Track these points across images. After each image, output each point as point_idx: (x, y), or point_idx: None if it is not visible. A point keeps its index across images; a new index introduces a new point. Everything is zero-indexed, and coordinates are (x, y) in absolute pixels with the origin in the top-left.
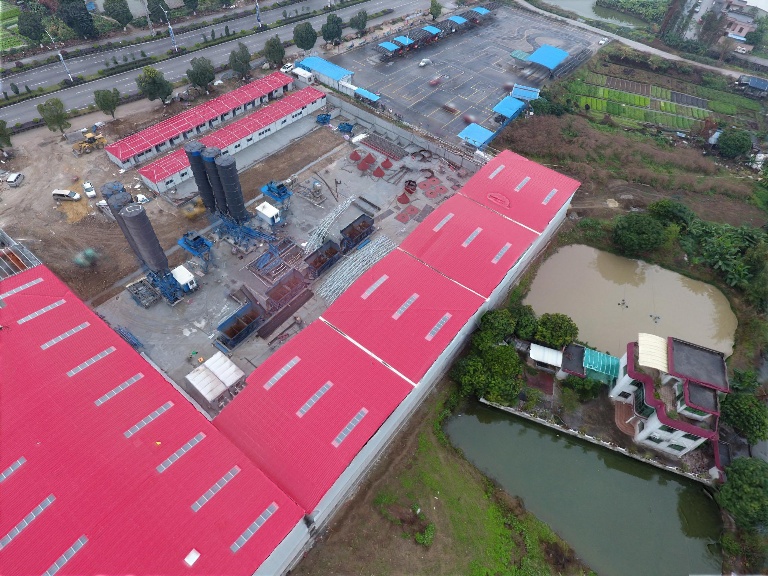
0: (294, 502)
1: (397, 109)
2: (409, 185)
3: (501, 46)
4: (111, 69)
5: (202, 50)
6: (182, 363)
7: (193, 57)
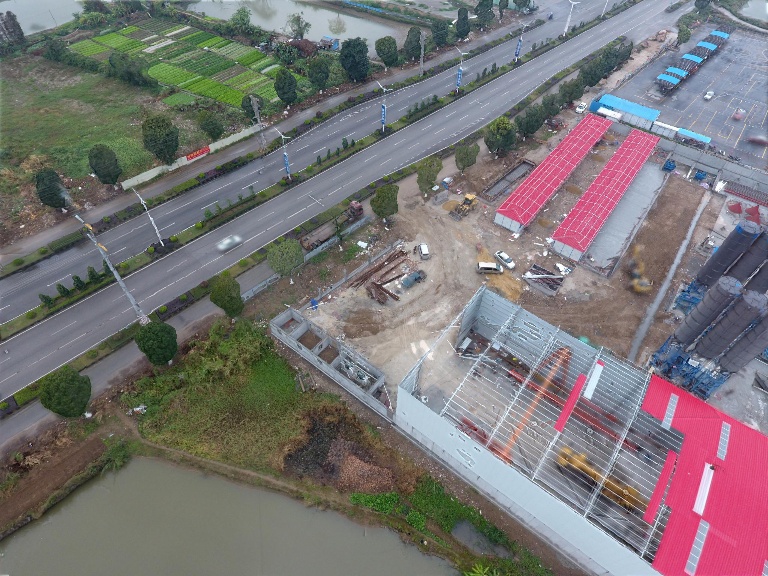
0: None
1: (726, 150)
2: None
3: (765, 73)
4: (410, 116)
5: (477, 90)
6: None
7: (475, 98)
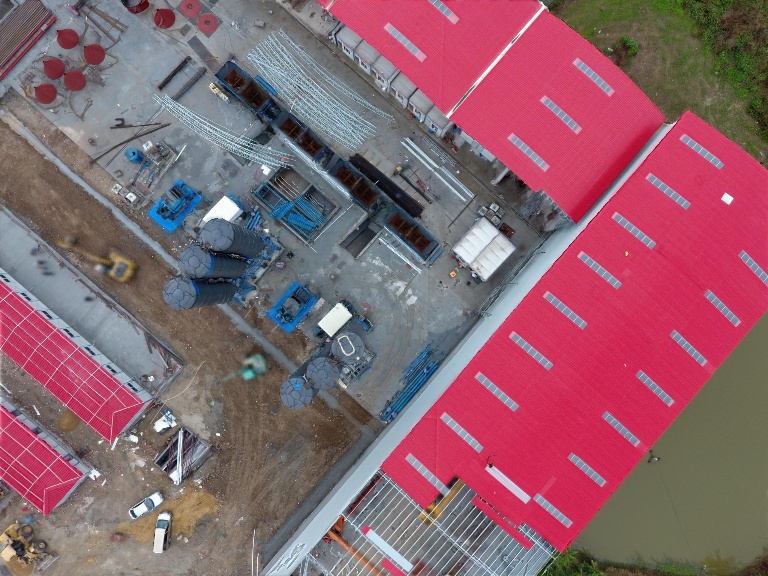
0: (679, 122)
1: None
2: (127, 5)
3: None
4: None
5: None
6: (453, 295)
7: None
